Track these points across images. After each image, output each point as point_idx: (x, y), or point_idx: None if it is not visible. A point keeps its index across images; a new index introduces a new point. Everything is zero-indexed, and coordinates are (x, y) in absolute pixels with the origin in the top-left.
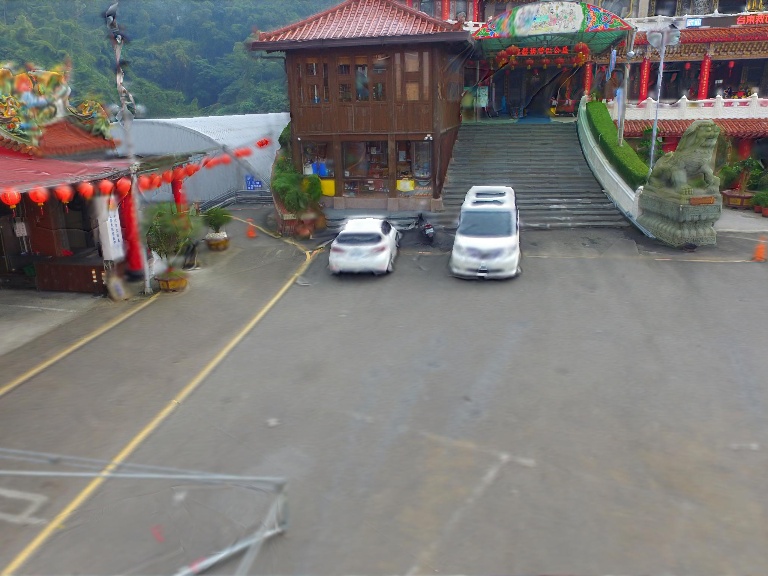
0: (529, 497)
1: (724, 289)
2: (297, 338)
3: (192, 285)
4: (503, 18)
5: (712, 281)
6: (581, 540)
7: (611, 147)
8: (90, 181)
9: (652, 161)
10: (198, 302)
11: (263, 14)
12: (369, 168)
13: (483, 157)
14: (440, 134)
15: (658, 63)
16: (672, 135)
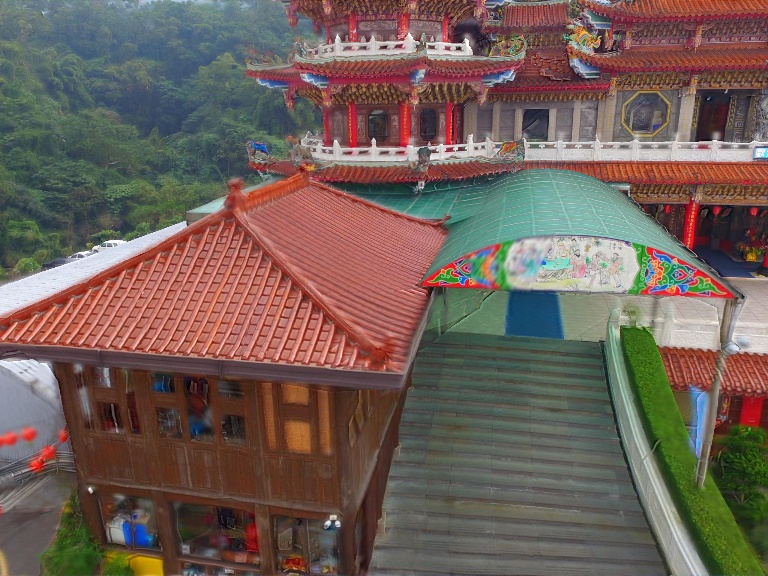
0: None
1: None
2: None
3: None
4: (483, 256)
5: None
6: None
7: (684, 494)
8: None
9: (748, 486)
10: None
11: (233, 33)
12: (225, 547)
13: (451, 441)
14: (356, 511)
15: (710, 206)
16: (766, 397)
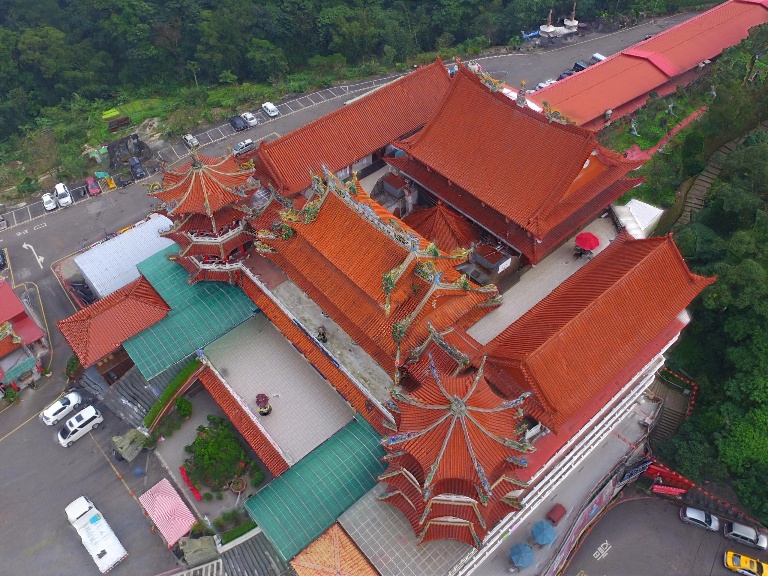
0: None
1: (88, 483)
2: None
3: (24, 401)
4: None
5: (94, 478)
6: None
7: (156, 401)
8: None
9: None
10: (15, 413)
11: None
12: None
13: None
14: None
15: None
16: None
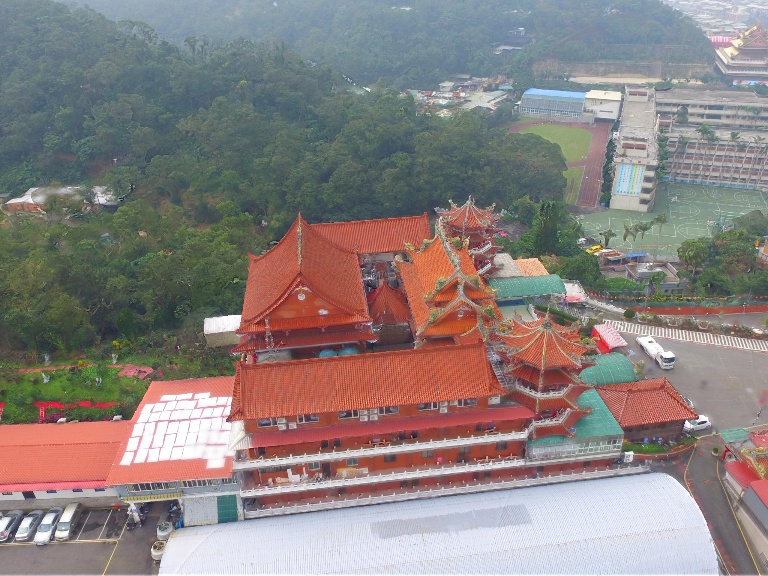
0: (745, 395)
1: None
2: (736, 422)
3: None
4: None
5: None
6: (746, 392)
7: None
8: (762, 434)
9: None
10: None
11: None
12: None
13: None
14: None
15: None
16: None
